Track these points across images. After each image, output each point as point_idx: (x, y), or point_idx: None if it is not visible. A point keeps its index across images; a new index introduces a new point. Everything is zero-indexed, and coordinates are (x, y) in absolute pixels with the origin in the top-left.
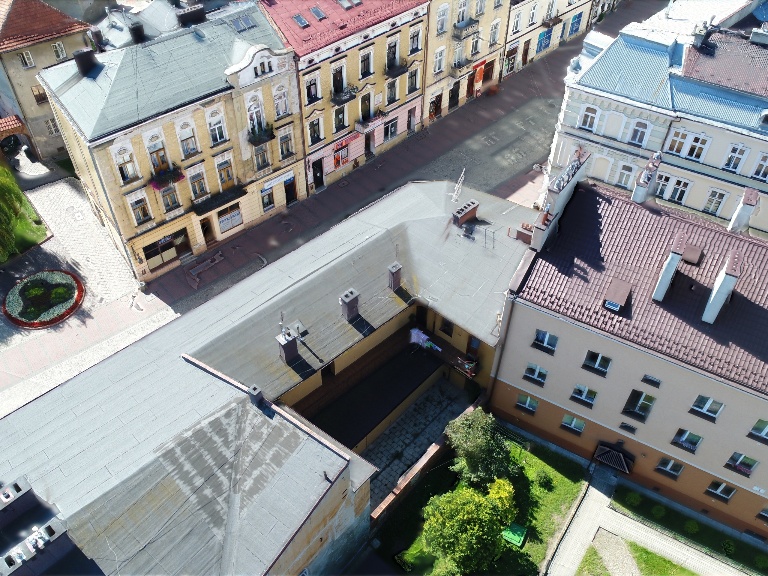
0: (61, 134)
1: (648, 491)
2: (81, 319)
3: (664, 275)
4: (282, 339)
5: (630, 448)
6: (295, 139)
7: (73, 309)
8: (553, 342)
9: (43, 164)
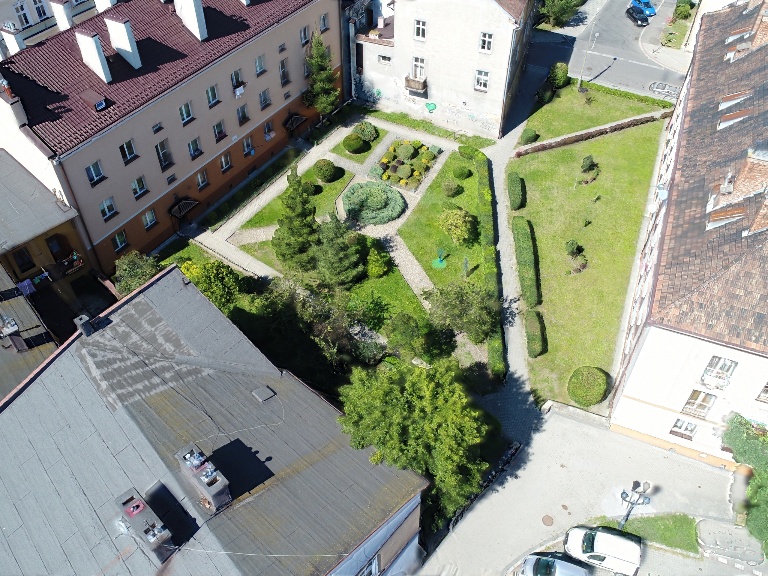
0: None
1: (208, 211)
2: None
3: (101, 59)
4: (10, 330)
5: (182, 193)
6: None
7: None
8: (97, 172)
9: None
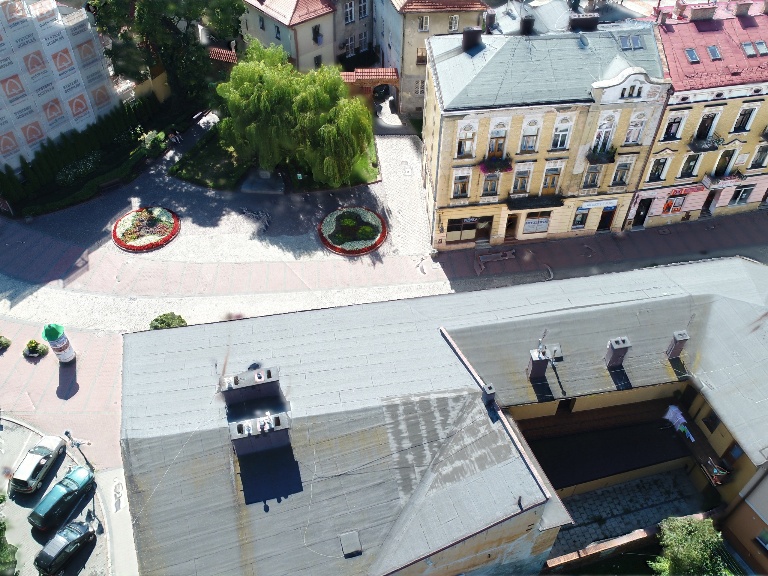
0: (424, 96)
1: None
2: (373, 260)
3: None
4: (535, 354)
5: None
6: (634, 170)
7: (371, 249)
8: None
9: (399, 117)
